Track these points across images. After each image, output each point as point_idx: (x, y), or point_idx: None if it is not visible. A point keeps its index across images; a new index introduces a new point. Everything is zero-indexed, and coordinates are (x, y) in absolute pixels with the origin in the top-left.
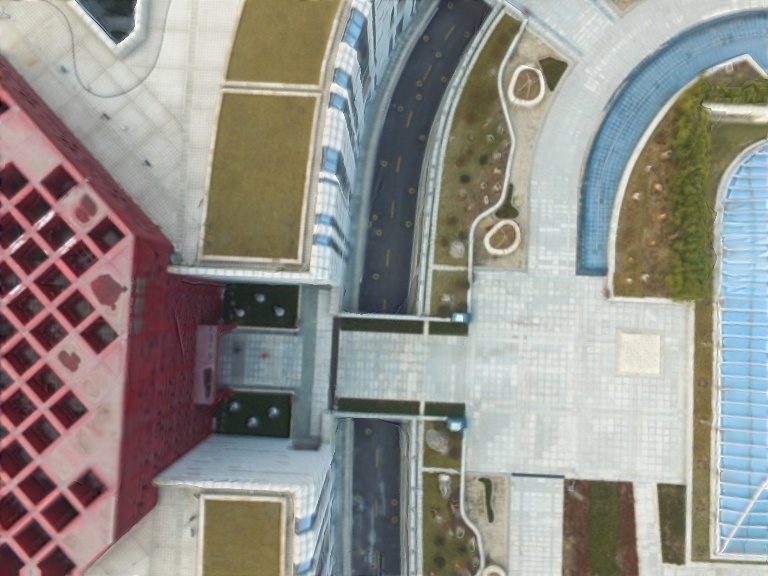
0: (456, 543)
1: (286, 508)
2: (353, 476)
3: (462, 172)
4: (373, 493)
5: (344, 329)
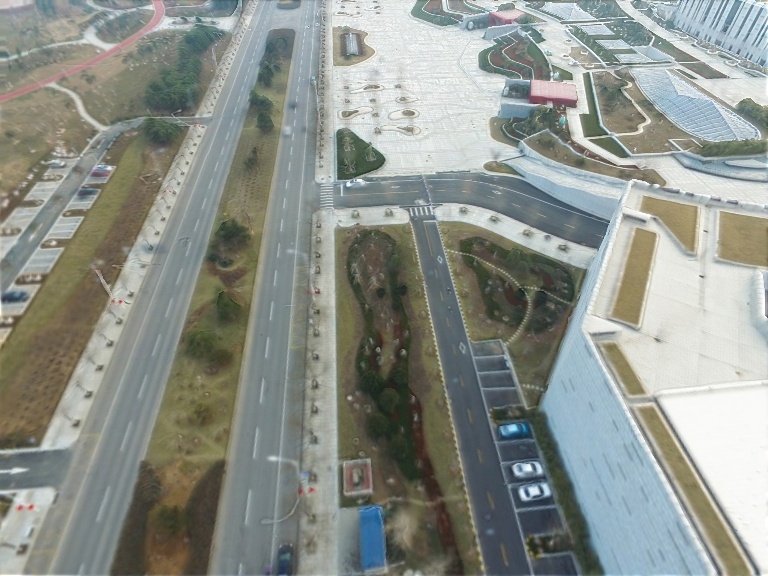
0: None
1: None
2: None
3: None
4: None
5: None
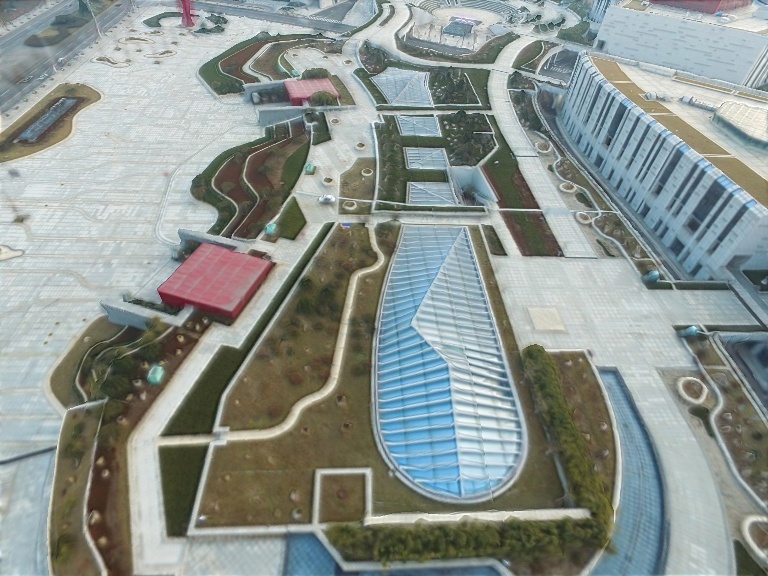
0: None
1: None
2: (671, 268)
3: (763, 443)
4: None
5: (759, 326)
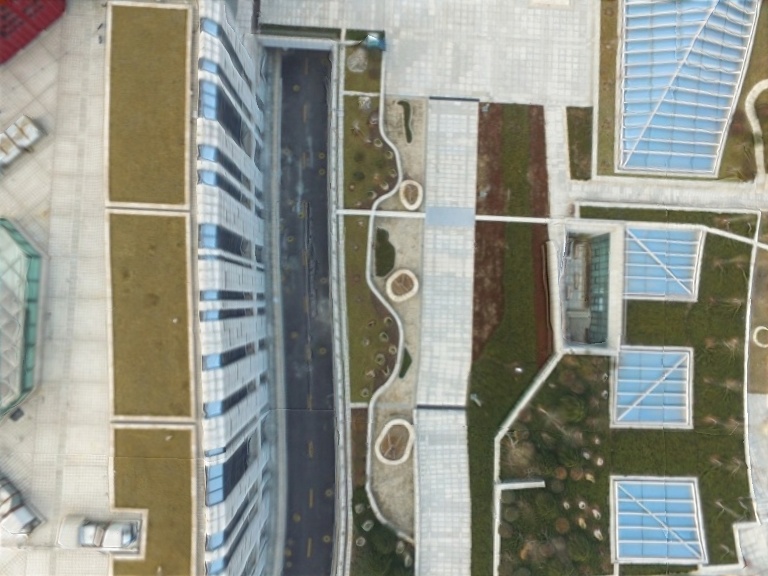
0: (375, 157)
1: (192, 16)
2: (281, 130)
3: None
4: (301, 147)
5: None
